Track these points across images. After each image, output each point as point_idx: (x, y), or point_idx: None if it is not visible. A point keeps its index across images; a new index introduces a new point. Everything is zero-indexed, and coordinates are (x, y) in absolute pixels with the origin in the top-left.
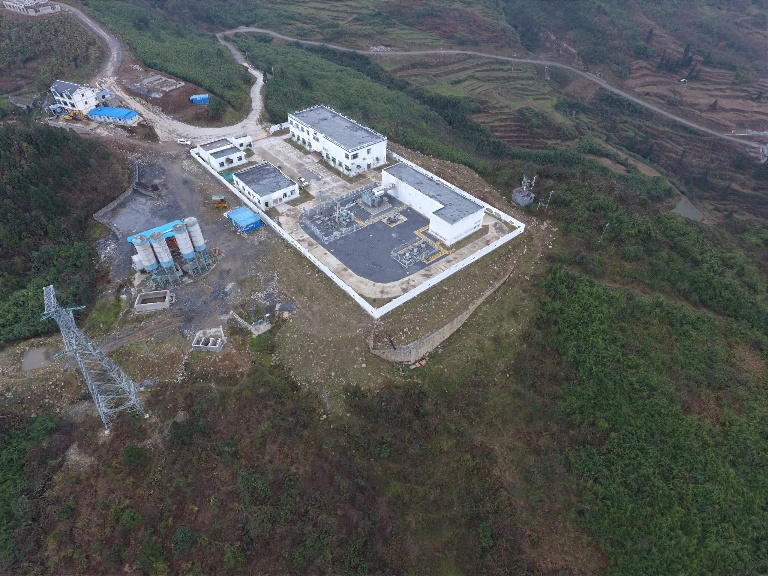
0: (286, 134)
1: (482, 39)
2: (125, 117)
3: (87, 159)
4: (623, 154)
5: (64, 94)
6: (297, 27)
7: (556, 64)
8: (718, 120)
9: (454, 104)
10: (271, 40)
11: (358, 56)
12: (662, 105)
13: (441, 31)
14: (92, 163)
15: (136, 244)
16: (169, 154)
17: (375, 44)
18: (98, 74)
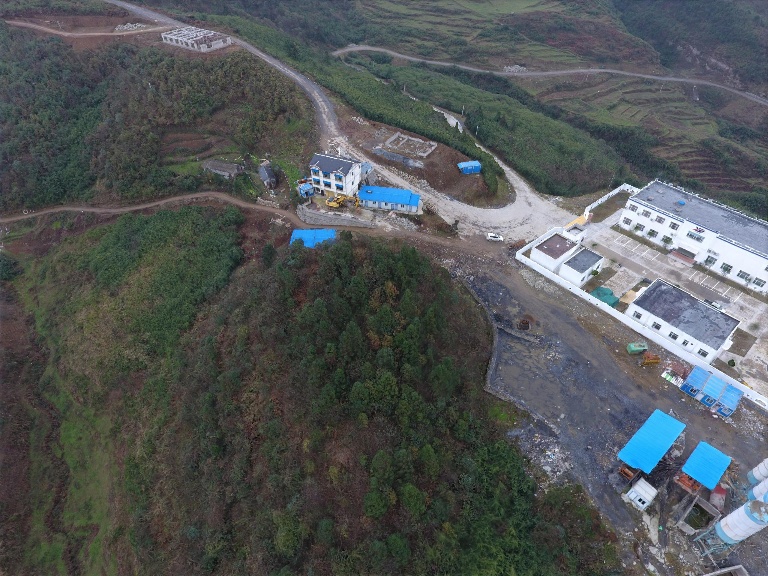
0: (606, 218)
1: (623, 55)
2: (410, 203)
3: (444, 291)
4: None
5: (333, 174)
6: (418, 45)
7: (706, 82)
8: None
9: (626, 135)
10: (390, 60)
11: (496, 78)
12: None
13: (576, 47)
14: (454, 298)
15: (762, 523)
16: (490, 259)
17: (508, 63)
18: (321, 132)
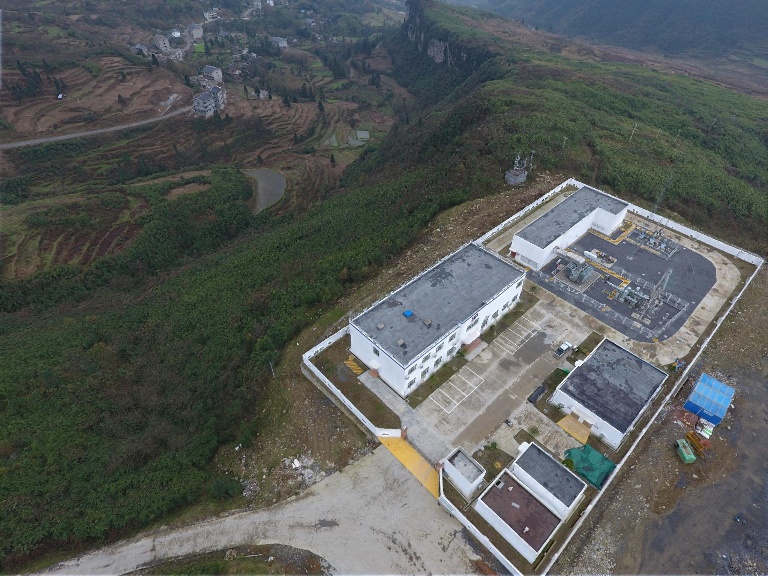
0: (388, 407)
1: None
2: None
3: None
4: (157, 180)
5: None
6: None
7: None
8: (141, 109)
9: None
10: None
11: None
12: (85, 127)
13: None
14: None
15: None
16: None
17: None
18: None
